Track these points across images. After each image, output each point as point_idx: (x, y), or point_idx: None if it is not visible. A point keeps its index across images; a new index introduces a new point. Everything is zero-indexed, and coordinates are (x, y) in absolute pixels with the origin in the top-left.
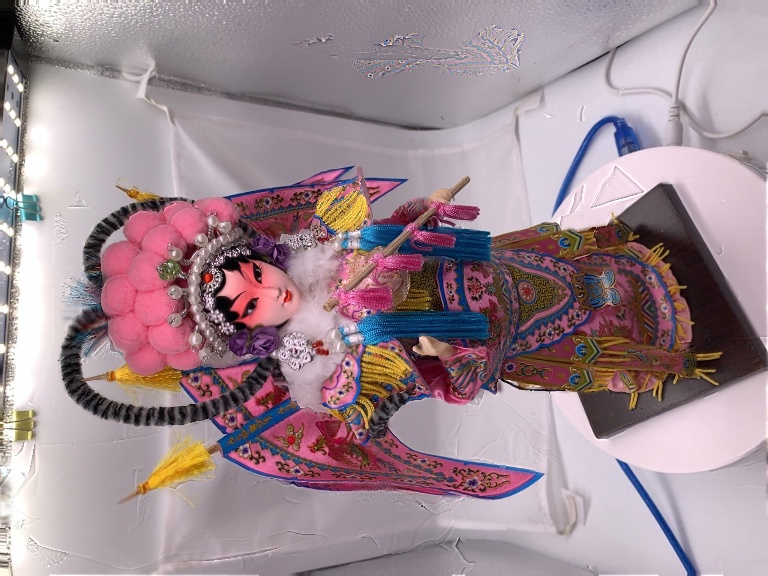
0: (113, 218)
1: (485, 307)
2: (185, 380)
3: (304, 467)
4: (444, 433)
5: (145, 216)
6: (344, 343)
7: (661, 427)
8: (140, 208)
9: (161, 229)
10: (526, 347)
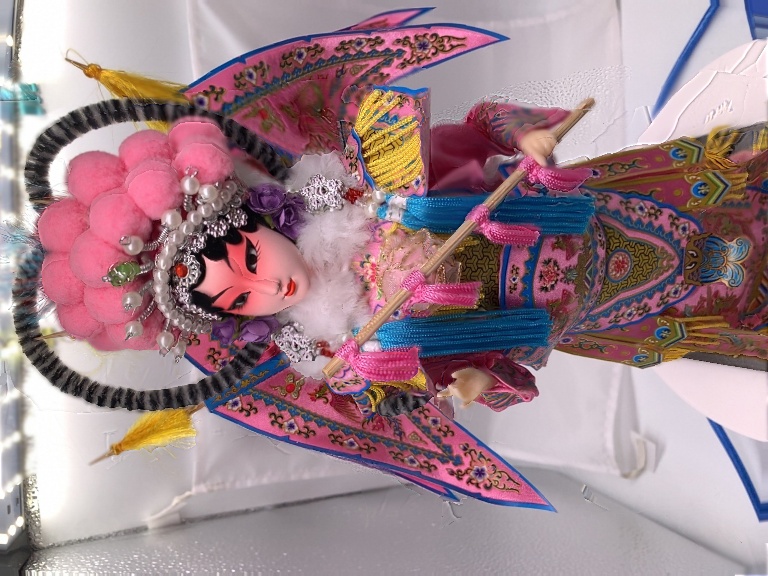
0: (61, 129)
1: (554, 299)
2: None
3: (300, 420)
4: None
5: (93, 171)
6: None
7: (723, 372)
8: (98, 117)
9: (112, 206)
10: (593, 327)
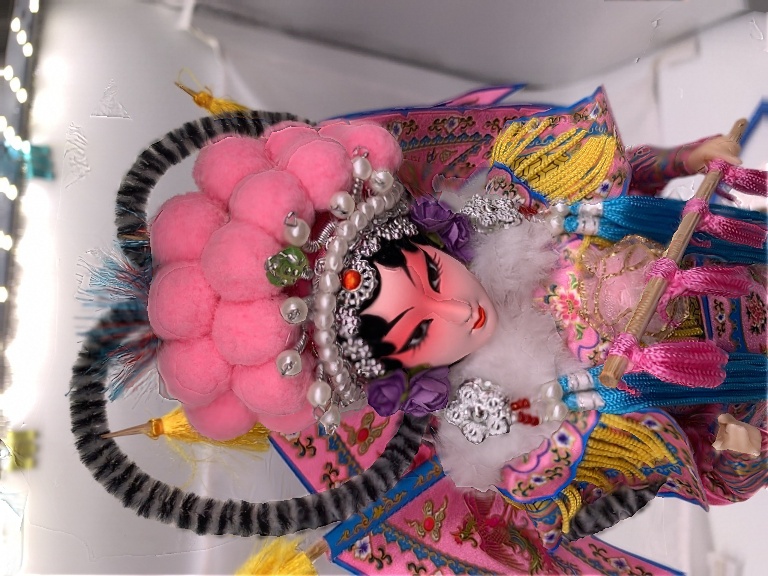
0: (171, 143)
1: (767, 345)
2: None
3: (449, 572)
4: (646, 517)
5: (238, 148)
6: (566, 406)
7: None
8: (219, 128)
9: (272, 179)
10: None
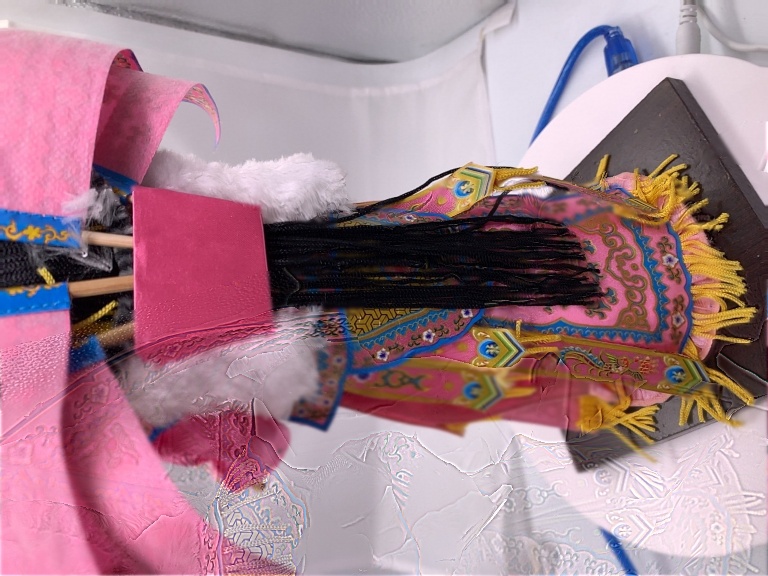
0: None
1: None
2: None
3: None
4: None
5: None
6: None
7: None
8: None
9: None
10: None
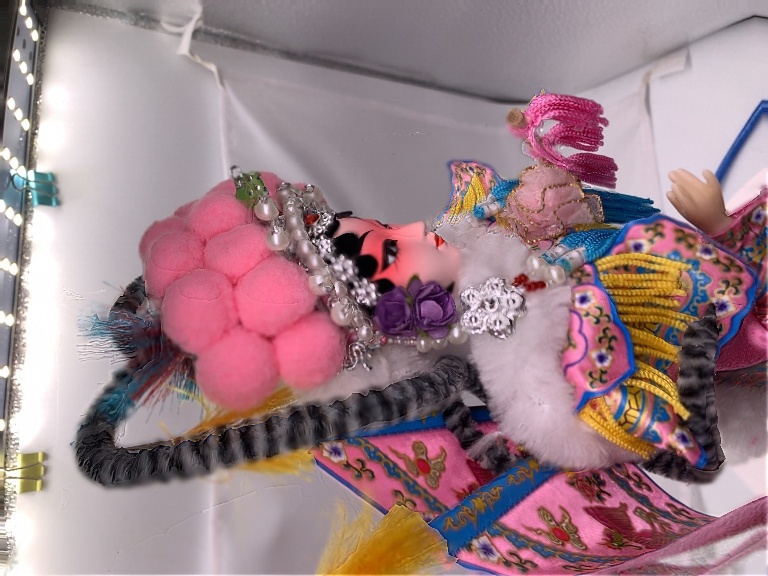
0: None
1: None
2: (317, 453)
3: None
4: None
5: None
6: (559, 267)
7: None
8: None
9: None
10: None
